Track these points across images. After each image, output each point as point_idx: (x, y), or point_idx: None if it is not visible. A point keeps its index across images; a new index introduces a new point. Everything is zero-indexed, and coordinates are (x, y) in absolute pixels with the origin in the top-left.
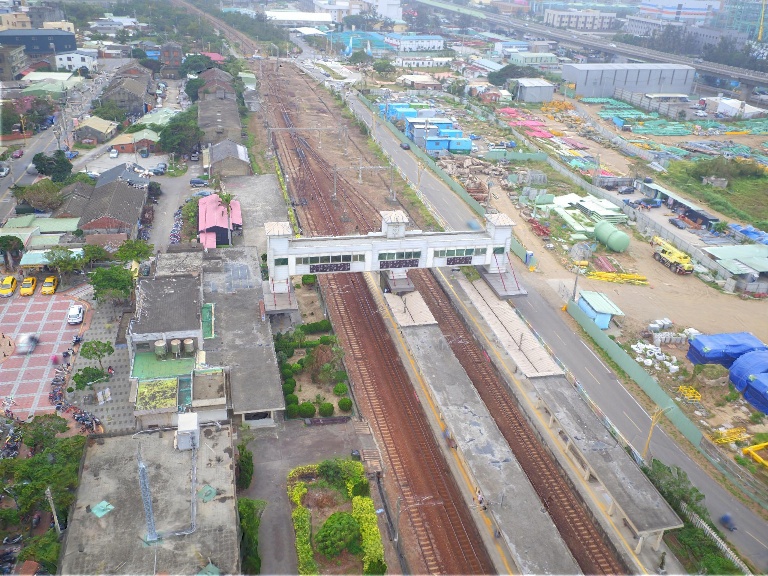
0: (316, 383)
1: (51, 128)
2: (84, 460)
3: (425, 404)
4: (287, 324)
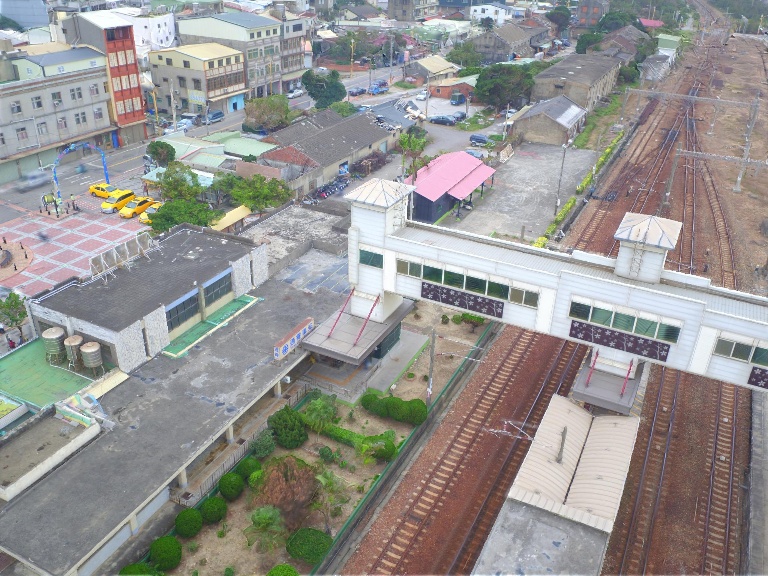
0: None
1: (397, 66)
2: None
3: None
4: (358, 380)
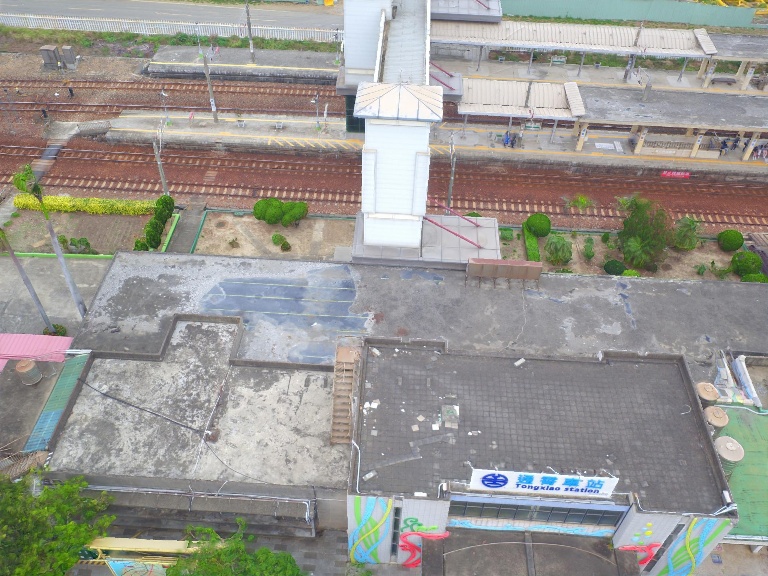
0: None
1: None
2: None
3: (712, 166)
4: None
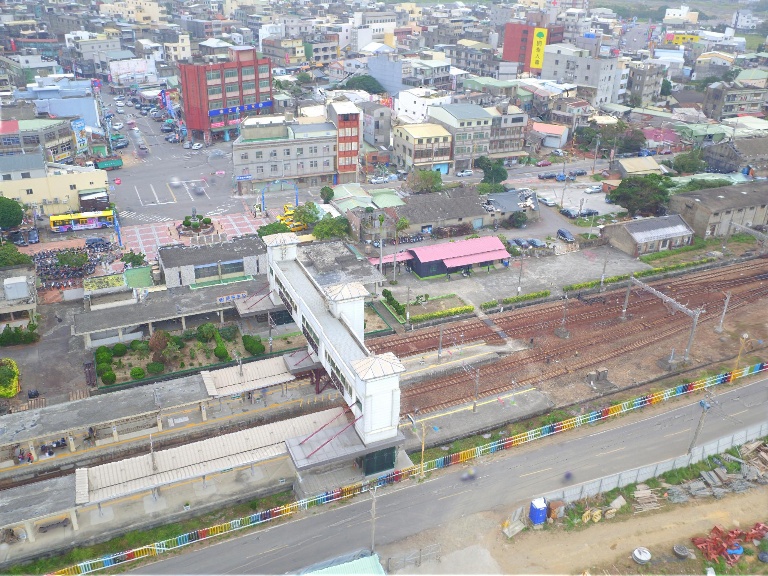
0: None
1: None
2: (12, 269)
3: None
4: (259, 330)
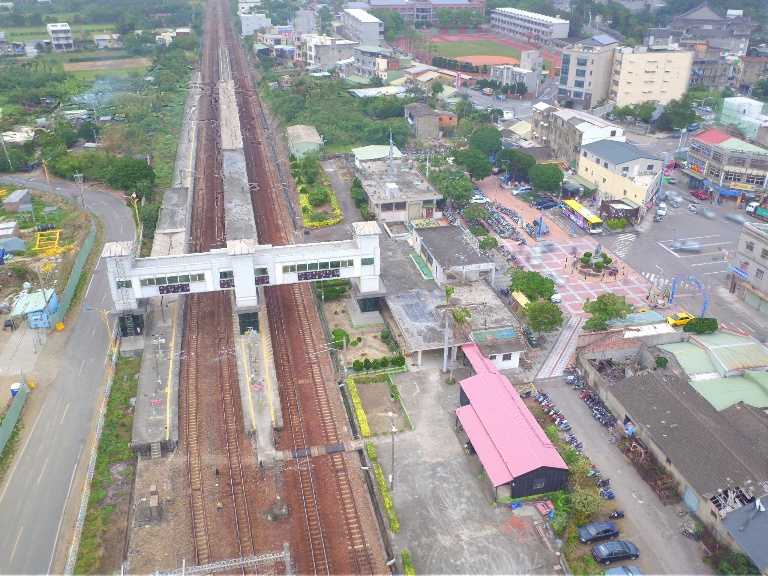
0: None
1: None
2: None
3: None
4: None
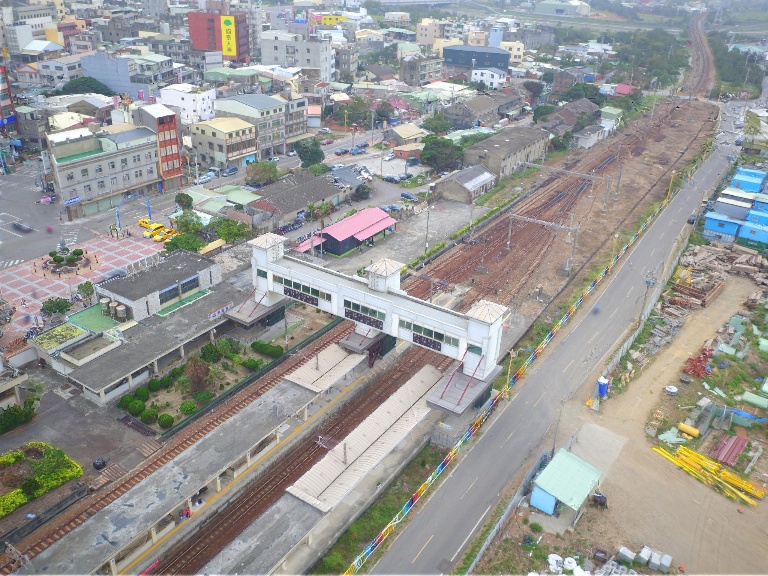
0: (189, 393)
1: None
2: None
3: None
4: None
